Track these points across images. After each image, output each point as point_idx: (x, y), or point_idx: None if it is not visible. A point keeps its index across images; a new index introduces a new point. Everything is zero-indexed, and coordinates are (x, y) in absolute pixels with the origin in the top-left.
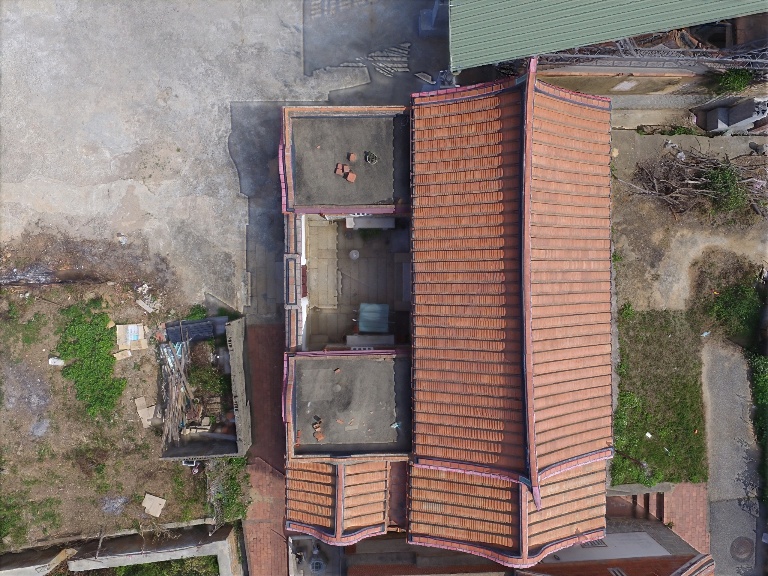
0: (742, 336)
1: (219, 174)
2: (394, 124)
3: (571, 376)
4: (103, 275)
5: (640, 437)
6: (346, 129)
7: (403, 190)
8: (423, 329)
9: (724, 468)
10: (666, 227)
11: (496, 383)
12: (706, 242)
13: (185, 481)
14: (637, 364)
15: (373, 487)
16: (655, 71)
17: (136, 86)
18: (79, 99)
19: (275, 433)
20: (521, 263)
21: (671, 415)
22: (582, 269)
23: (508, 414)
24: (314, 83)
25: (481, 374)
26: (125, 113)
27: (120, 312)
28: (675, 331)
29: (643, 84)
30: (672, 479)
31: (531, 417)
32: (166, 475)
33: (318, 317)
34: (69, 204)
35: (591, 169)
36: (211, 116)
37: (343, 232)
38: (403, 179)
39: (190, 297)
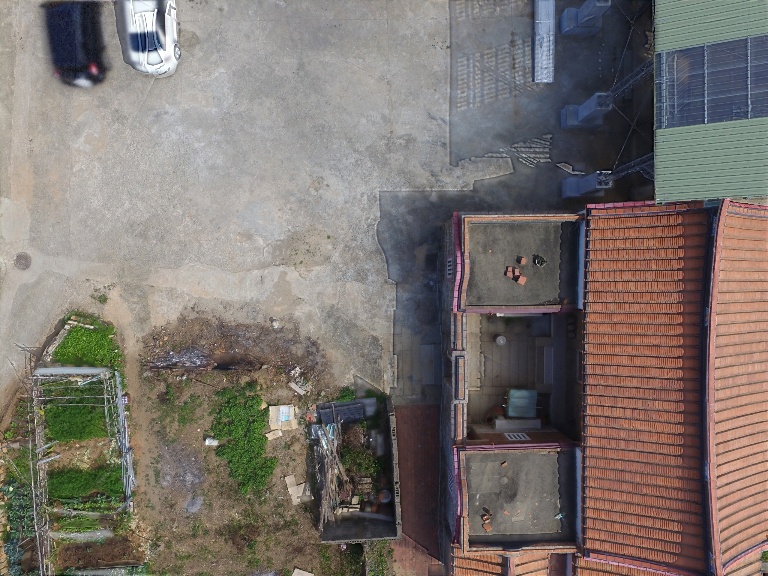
0: None
1: (368, 260)
2: (562, 228)
3: (739, 476)
4: (257, 358)
5: None
6: (516, 234)
7: (568, 291)
8: (595, 429)
9: None
10: None
11: (673, 486)
12: None
13: (332, 556)
14: None
15: (537, 575)
16: None
17: (289, 176)
18: (234, 188)
19: (418, 510)
20: (705, 375)
21: None
22: (747, 372)
23: (687, 517)
24: (459, 173)
25: (657, 476)
26: (278, 202)
27: (272, 393)
28: None
29: None
30: None
31: (716, 524)
32: (314, 550)
33: None
34: (224, 289)
35: (756, 276)
36: (360, 205)
37: (486, 316)
38: (569, 280)
39: (339, 379)
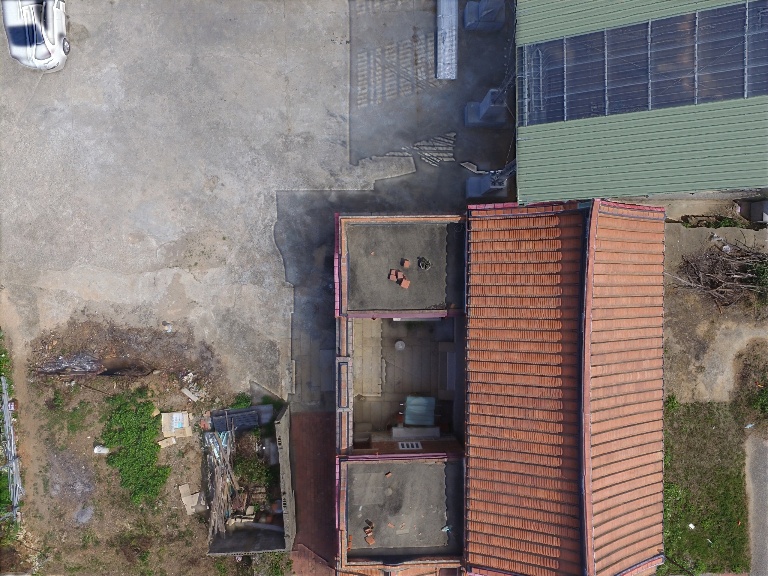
0: None
1: (265, 262)
2: (448, 230)
3: (625, 488)
4: (149, 363)
5: (683, 529)
6: (400, 235)
7: (455, 295)
8: (477, 439)
9: (766, 559)
10: (711, 320)
11: (552, 499)
12: (750, 334)
13: (228, 568)
14: (681, 456)
15: None
16: None
17: (182, 175)
18: (126, 187)
19: (318, 520)
20: (581, 384)
21: (714, 506)
22: (636, 380)
23: (565, 531)
24: (360, 172)
25: (537, 488)
26: (171, 201)
27: (165, 400)
28: (719, 423)
29: None
30: (715, 570)
31: (590, 539)
32: (209, 562)
33: (362, 405)
34: (115, 292)
35: (646, 280)
36: (257, 205)
37: (388, 321)
38: (456, 284)
39: (235, 385)
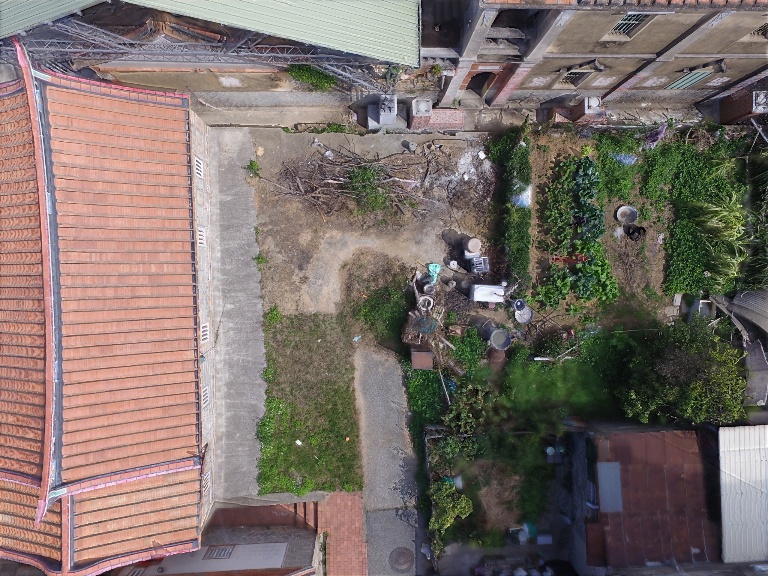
0: (389, 341)
1: None
2: None
3: (133, 383)
4: None
5: (289, 445)
6: None
7: None
8: None
9: (380, 477)
10: (314, 228)
11: (38, 391)
12: (357, 244)
13: None
14: (285, 369)
15: None
16: (231, 67)
17: None
18: None
19: None
20: None
21: (322, 422)
22: (151, 272)
23: None
24: None
25: (28, 382)
26: None
27: None
28: (325, 335)
29: (246, 80)
30: (324, 488)
31: (48, 427)
32: None
33: None
34: None
35: (160, 168)
36: None
37: None
38: None
39: None
